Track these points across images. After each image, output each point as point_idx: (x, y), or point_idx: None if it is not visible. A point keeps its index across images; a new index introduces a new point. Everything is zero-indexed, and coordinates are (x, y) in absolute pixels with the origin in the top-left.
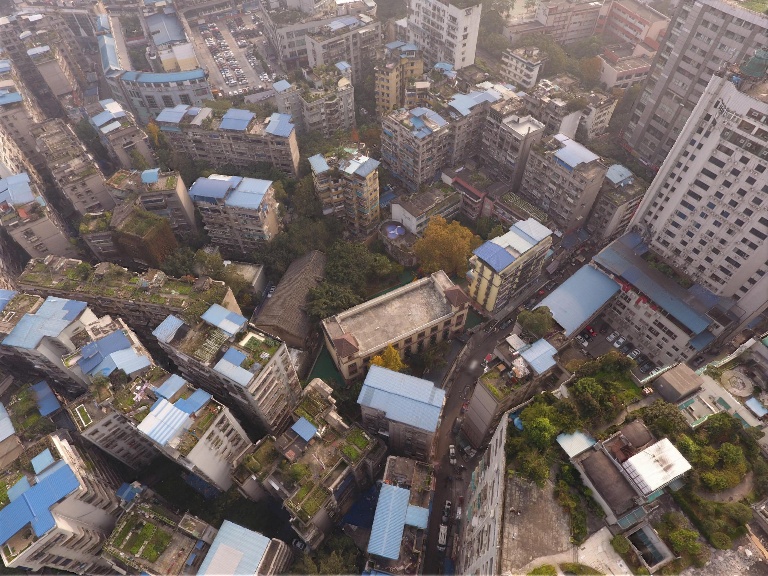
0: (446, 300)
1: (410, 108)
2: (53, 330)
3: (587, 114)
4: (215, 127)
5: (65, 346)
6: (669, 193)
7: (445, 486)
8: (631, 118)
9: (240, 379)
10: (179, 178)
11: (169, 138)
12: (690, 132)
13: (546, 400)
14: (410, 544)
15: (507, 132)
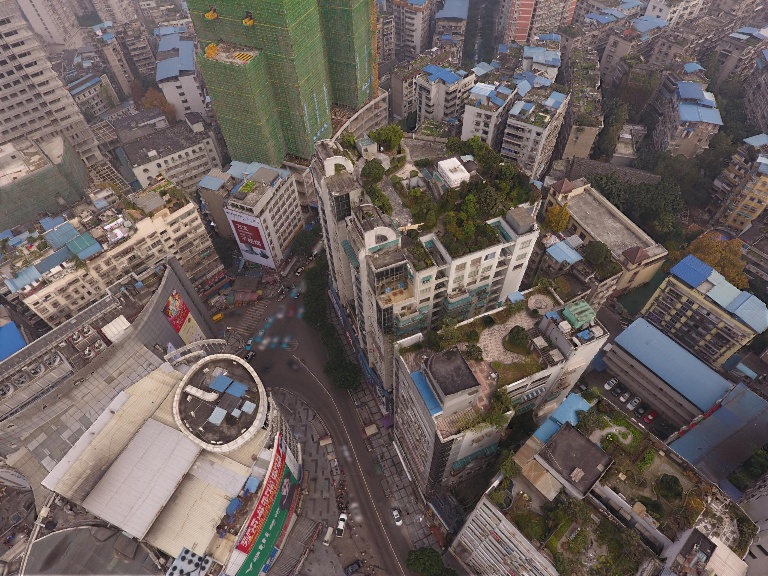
0: None
1: None
2: (537, 59)
3: None
4: None
5: None
6: None
7: None
8: None
9: (513, 111)
10: (704, 86)
11: (753, 71)
12: None
13: None
14: None
15: None
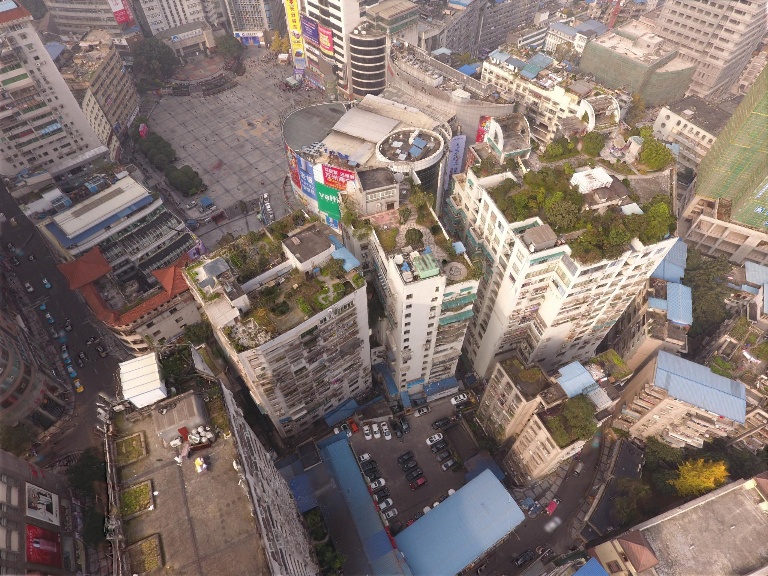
0: None
1: None
2: None
3: None
4: None
5: None
6: None
7: None
8: None
9: None
10: None
11: None
12: None
13: (648, 239)
14: (657, 294)
15: None
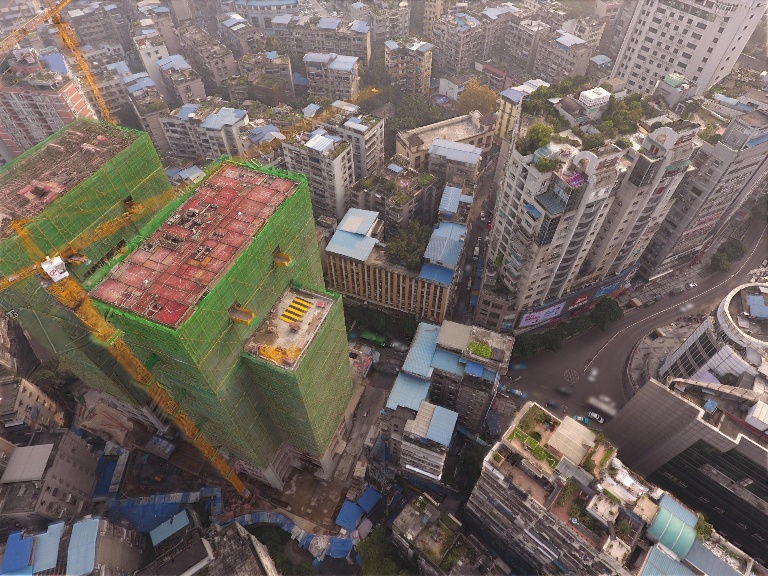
0: (480, 125)
1: None
2: (230, 122)
3: (583, 32)
4: (313, 28)
5: (233, 137)
6: (631, 54)
7: (478, 231)
8: (615, 33)
9: (360, 129)
10: (289, 59)
11: (277, 38)
12: (642, 5)
13: None
14: (462, 212)
15: (523, 31)
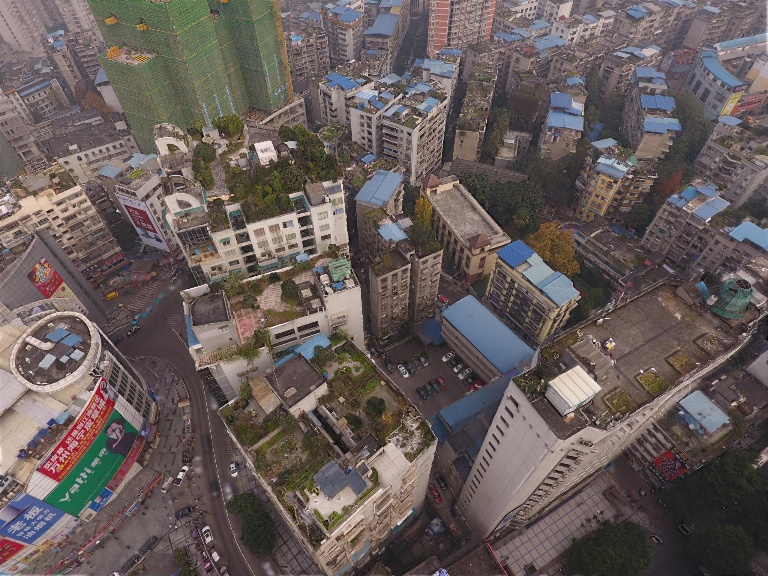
0: None
1: (764, 224)
2: (434, 70)
3: None
4: None
5: None
6: None
7: None
8: None
9: (387, 113)
10: (583, 98)
11: None
12: None
13: None
14: None
15: None
